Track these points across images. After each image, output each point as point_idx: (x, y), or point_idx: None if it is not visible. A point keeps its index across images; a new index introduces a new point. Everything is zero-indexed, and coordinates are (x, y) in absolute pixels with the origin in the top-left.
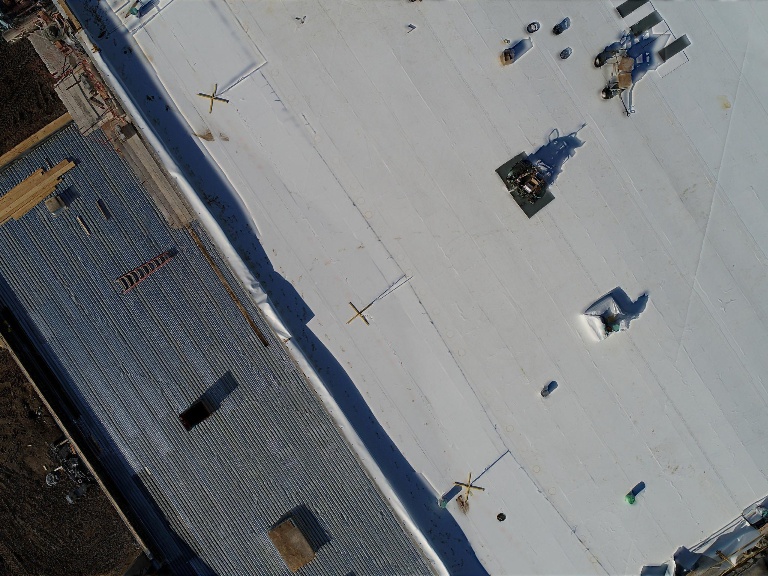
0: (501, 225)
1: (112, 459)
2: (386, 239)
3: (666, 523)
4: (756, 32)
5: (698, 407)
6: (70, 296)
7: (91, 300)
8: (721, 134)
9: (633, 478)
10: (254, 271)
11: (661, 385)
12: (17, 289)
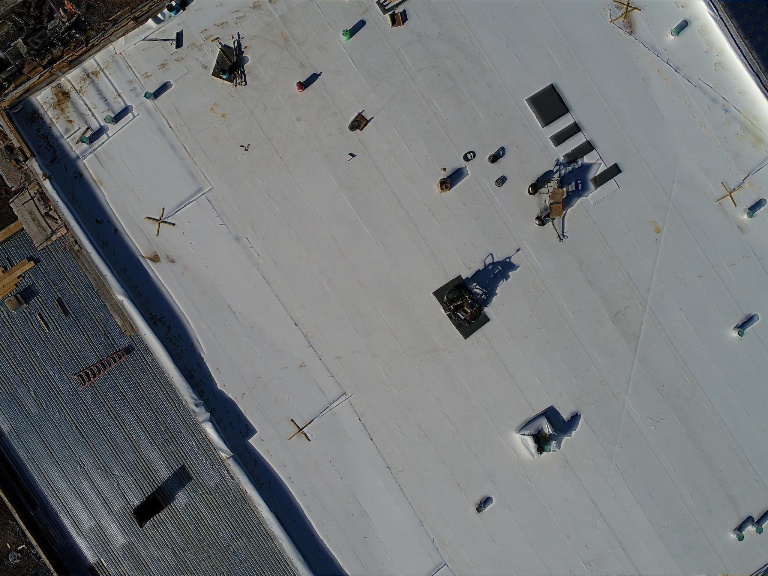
0: (438, 346)
1: (69, 550)
2: (327, 358)
3: None
4: (684, 161)
5: (630, 523)
6: (29, 391)
7: (49, 395)
8: (651, 259)
9: None
10: (198, 389)
11: (594, 501)
12: None
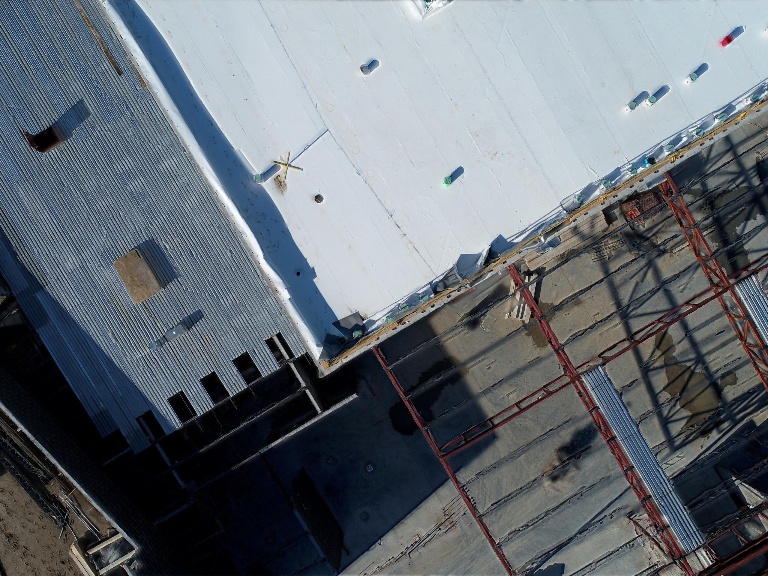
0: None
1: None
2: None
3: (484, 211)
4: None
5: (520, 92)
6: None
7: None
8: None
9: (452, 162)
10: None
11: (483, 67)
12: None
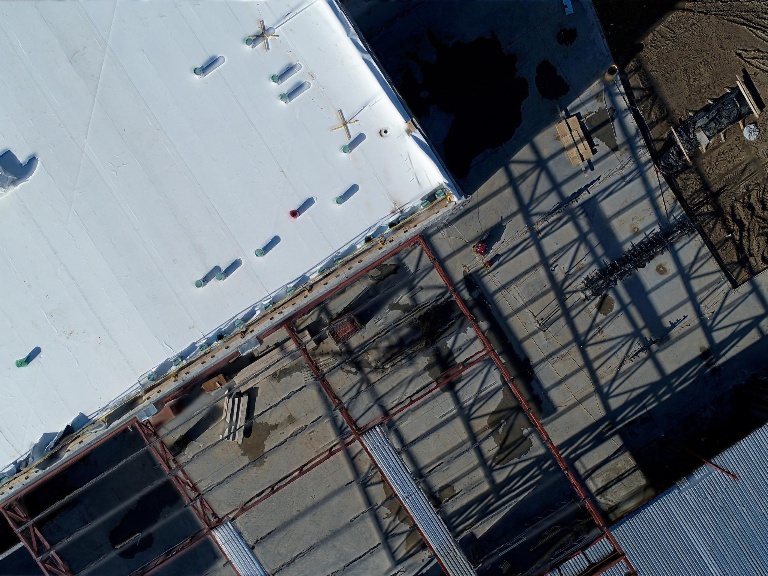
0: None
1: None
2: None
3: (64, 389)
4: None
5: (91, 272)
6: None
7: None
8: None
9: (29, 343)
10: None
11: (53, 249)
12: None
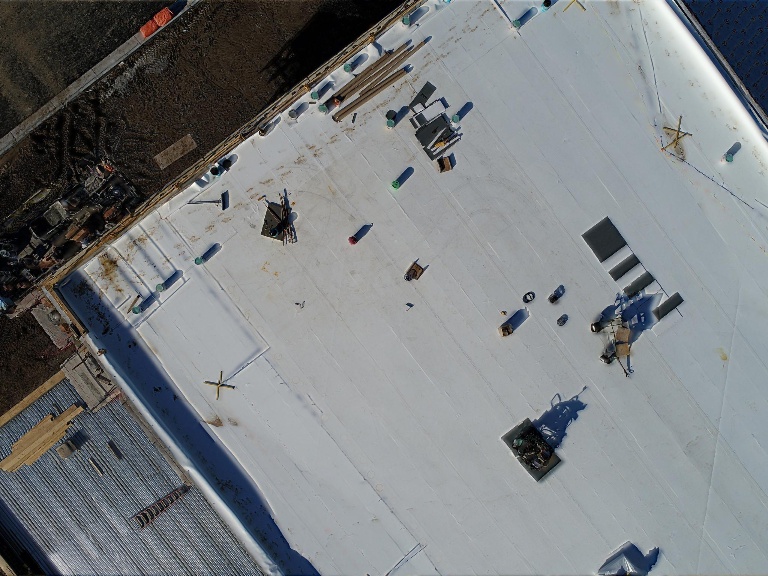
0: (510, 490)
1: None
2: (398, 510)
3: None
4: (746, 285)
5: None
6: (87, 536)
7: (108, 538)
8: (719, 386)
9: None
10: (271, 552)
11: None
12: (34, 532)
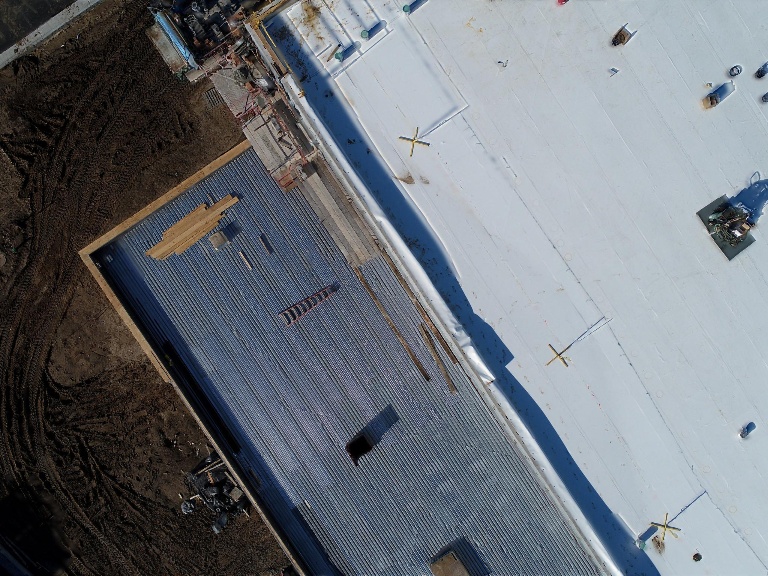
0: (701, 267)
1: (272, 492)
2: (585, 281)
3: None
4: None
5: None
6: (231, 330)
7: (252, 334)
8: None
9: None
10: (455, 314)
11: None
12: (178, 323)
